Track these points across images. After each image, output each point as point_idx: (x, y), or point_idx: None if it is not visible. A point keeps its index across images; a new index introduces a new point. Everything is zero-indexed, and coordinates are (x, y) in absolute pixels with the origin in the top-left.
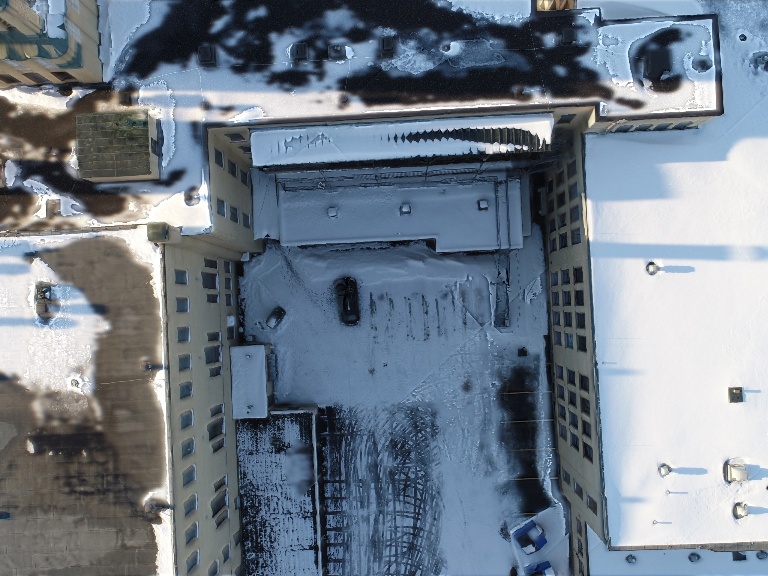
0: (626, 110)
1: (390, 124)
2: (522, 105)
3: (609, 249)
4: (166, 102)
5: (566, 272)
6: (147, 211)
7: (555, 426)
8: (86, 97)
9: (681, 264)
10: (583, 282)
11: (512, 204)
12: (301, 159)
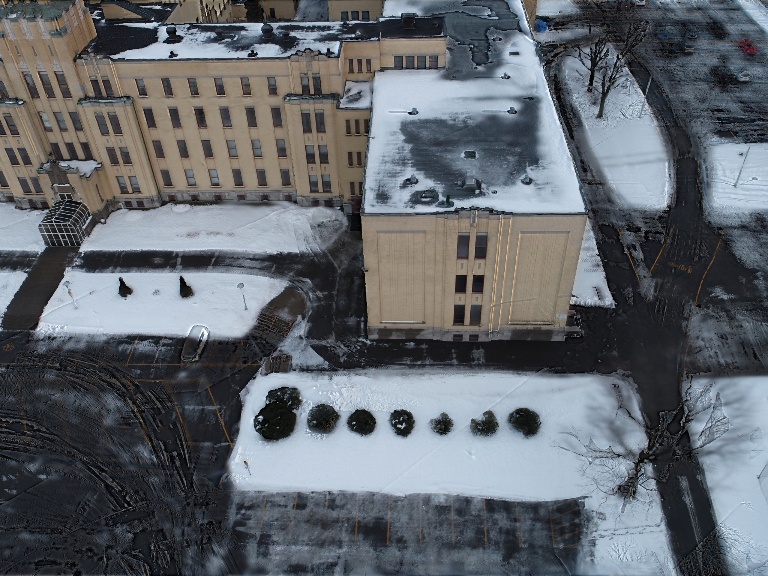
0: None
1: None
2: None
3: None
4: None
5: None
6: None
7: None
8: None
9: None
10: None
11: None
12: None
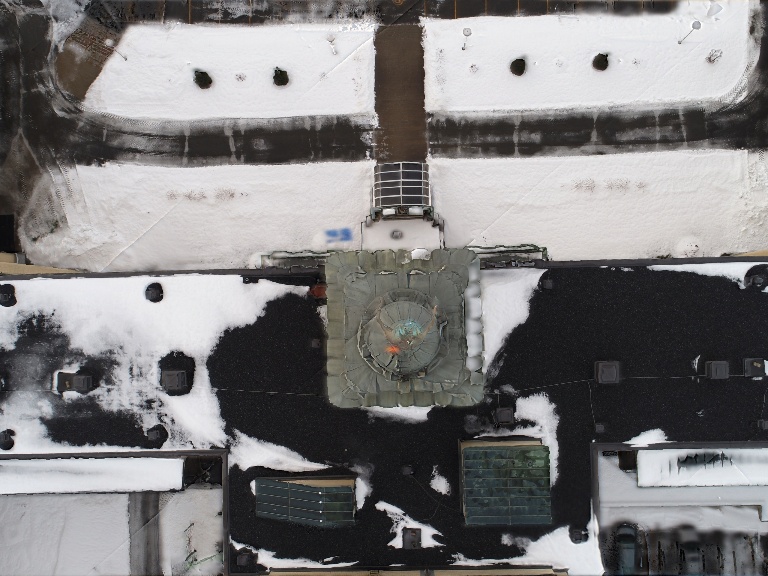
0: None
1: None
2: None
3: None
4: (549, 418)
5: None
6: (523, 546)
7: None
8: (451, 406)
9: None
10: None
11: None
12: (696, 482)
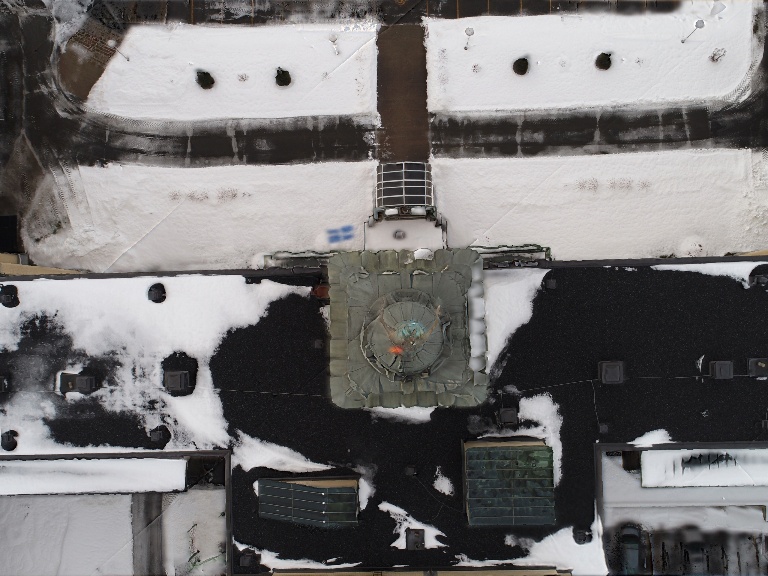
0: None
1: None
2: None
3: None
4: (552, 419)
5: None
6: (527, 547)
7: None
8: (454, 407)
9: None
10: None
11: None
12: (701, 482)
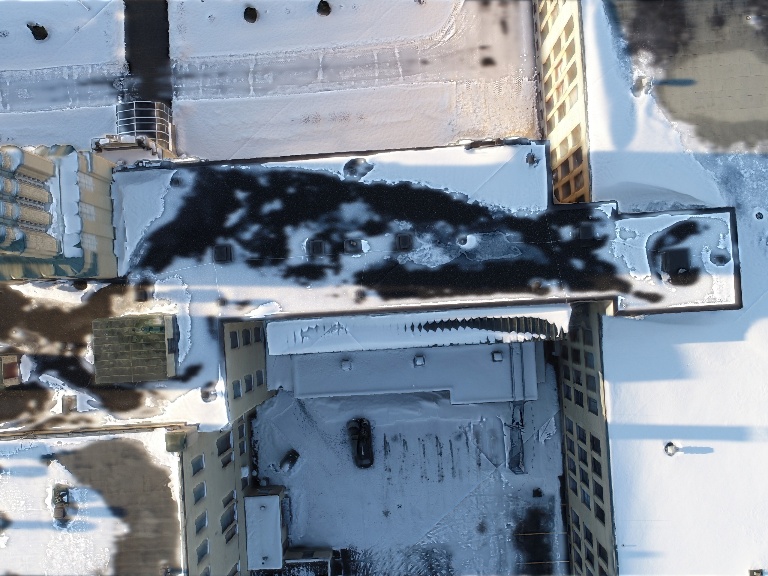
0: (644, 304)
1: (407, 314)
2: (540, 299)
3: (627, 430)
4: (182, 297)
5: (582, 429)
6: (164, 407)
7: (571, 568)
8: (101, 291)
9: (700, 445)
10: (601, 457)
11: (526, 355)
12: (317, 349)
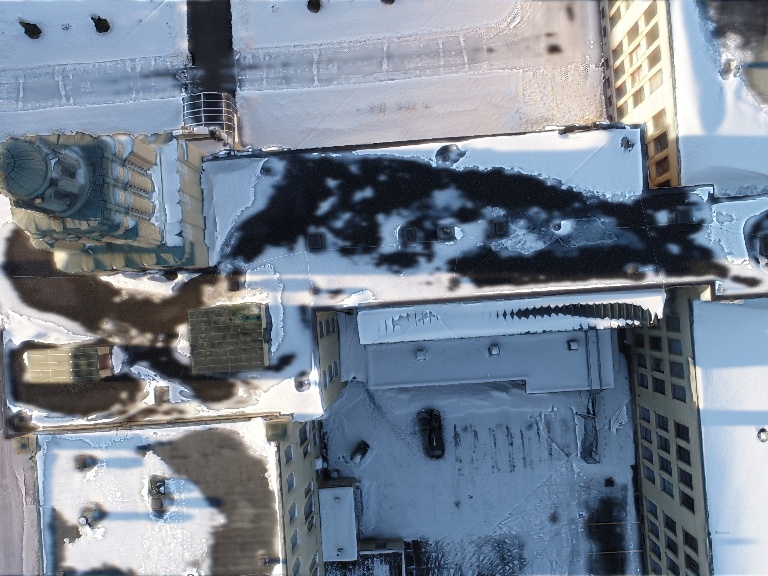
0: (742, 288)
1: (499, 301)
2: (636, 285)
3: (720, 417)
4: (274, 286)
5: (662, 417)
6: (257, 397)
7: (644, 557)
8: (192, 281)
9: None
10: (690, 444)
11: (602, 344)
12: (409, 337)
